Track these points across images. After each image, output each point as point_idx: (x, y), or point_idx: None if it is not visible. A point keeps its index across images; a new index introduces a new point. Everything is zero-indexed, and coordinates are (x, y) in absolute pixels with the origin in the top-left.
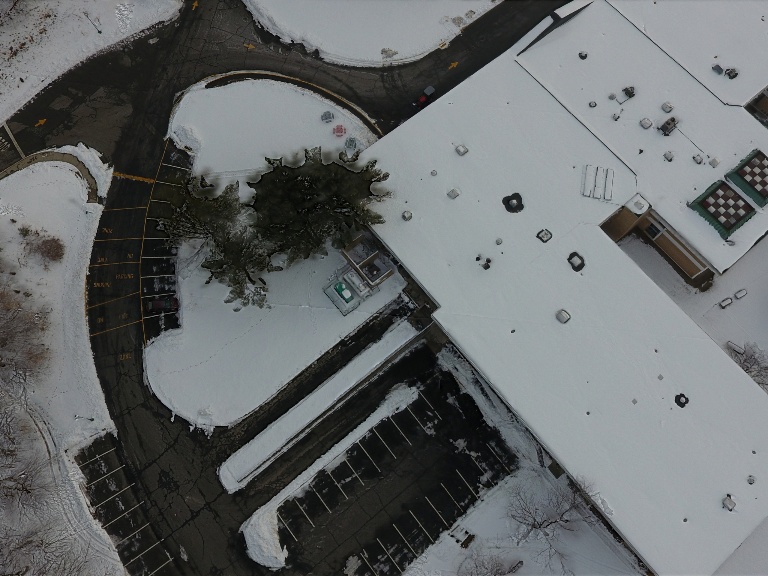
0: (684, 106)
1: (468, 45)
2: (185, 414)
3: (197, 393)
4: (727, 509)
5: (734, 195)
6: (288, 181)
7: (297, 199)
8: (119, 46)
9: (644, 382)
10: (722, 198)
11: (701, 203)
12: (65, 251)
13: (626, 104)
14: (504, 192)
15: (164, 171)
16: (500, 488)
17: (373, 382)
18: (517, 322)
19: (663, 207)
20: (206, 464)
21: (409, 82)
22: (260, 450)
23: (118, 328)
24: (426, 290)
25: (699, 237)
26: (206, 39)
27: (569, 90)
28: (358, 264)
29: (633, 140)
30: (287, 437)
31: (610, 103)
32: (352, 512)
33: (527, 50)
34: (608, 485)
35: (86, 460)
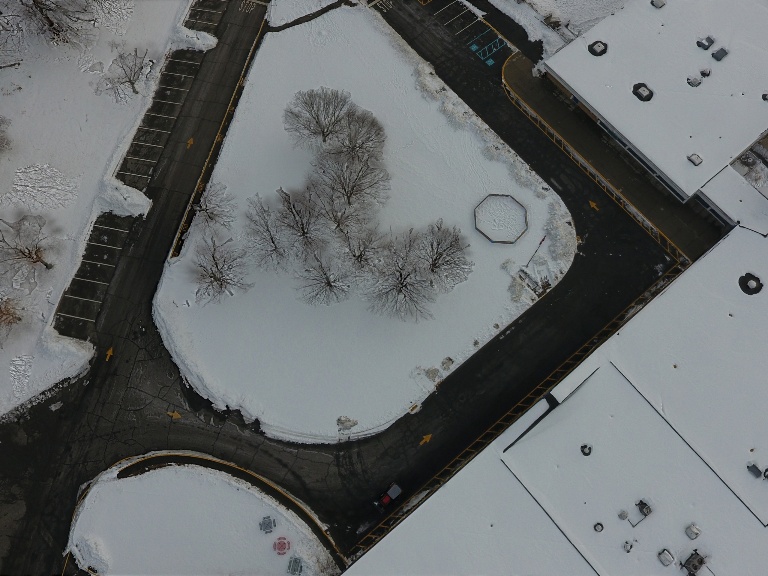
0: (713, 529)
1: (444, 408)
2: None
3: None
4: None
5: None
6: None
7: None
8: (13, 416)
9: None
10: None
11: None
12: None
13: (640, 526)
14: None
15: None
16: None
17: None
18: None
19: None
20: None
21: (370, 466)
22: None
23: None
24: None
25: None
26: (121, 404)
27: (569, 505)
28: None
29: None
30: None
31: (620, 525)
32: None
33: (516, 443)
34: None
35: None
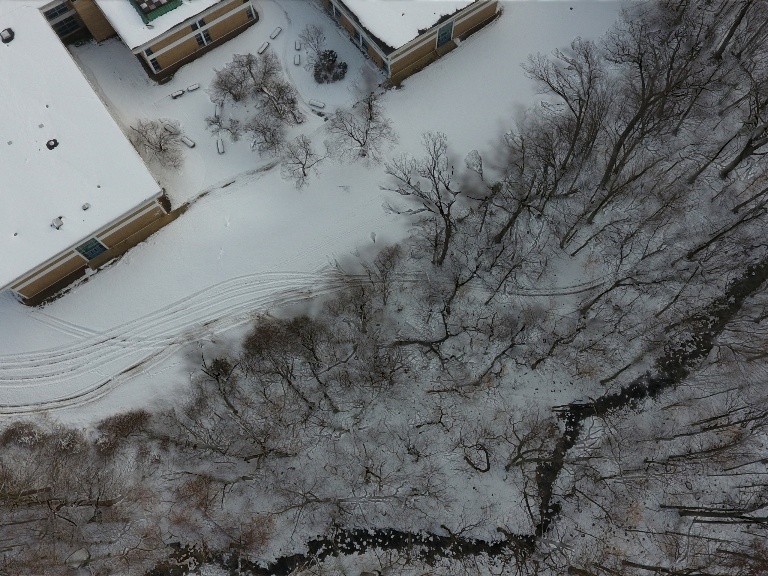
0: None
1: None
2: None
3: None
4: (55, 227)
5: None
6: None
7: None
8: None
9: (25, 129)
10: None
11: None
12: None
13: None
14: None
15: None
16: None
17: None
18: None
19: None
20: None
21: None
22: None
23: None
24: None
25: (123, 21)
26: None
27: None
28: None
29: None
30: None
31: None
32: None
33: None
34: None
35: None
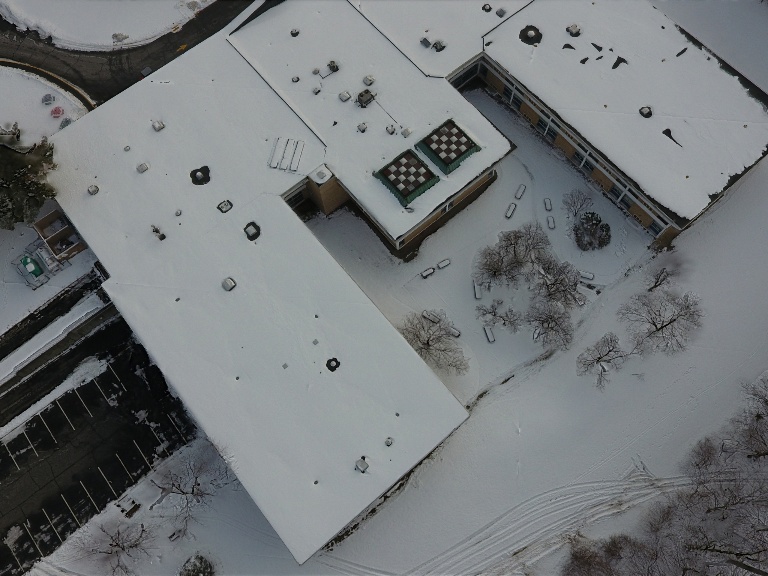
0: (386, 79)
1: (200, 28)
2: None
3: None
4: (360, 471)
5: (417, 163)
6: None
7: None
8: None
9: (298, 347)
10: (404, 166)
11: (382, 171)
12: None
13: (329, 78)
14: (193, 165)
15: None
16: (173, 458)
17: (64, 355)
18: (183, 290)
19: (347, 176)
20: None
21: (136, 65)
22: None
23: None
24: (99, 261)
25: (378, 205)
26: None
27: (275, 66)
28: (45, 238)
29: (329, 113)
30: None
31: (313, 78)
32: (22, 483)
33: (240, 29)
34: (244, 448)
35: None
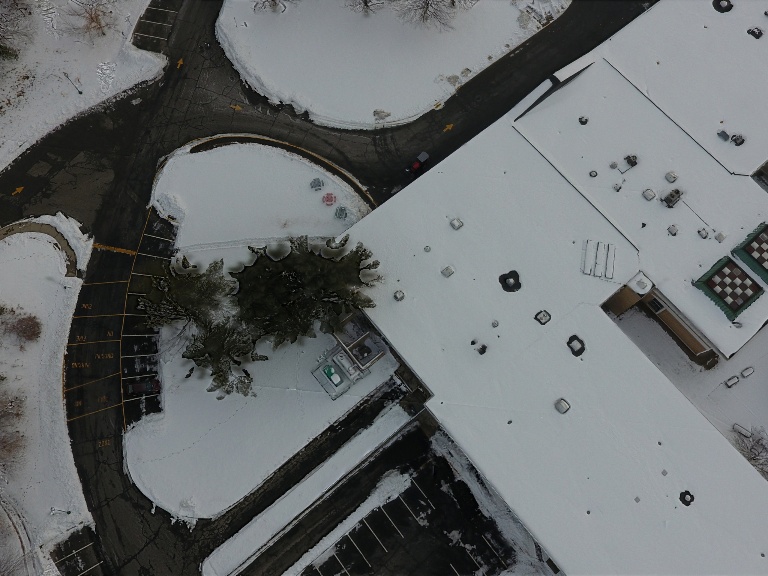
0: (689, 176)
1: (464, 106)
2: (166, 506)
3: (179, 483)
4: None
5: (741, 273)
6: (272, 277)
7: (281, 294)
8: (100, 107)
9: (647, 478)
10: (729, 277)
11: (707, 282)
12: (42, 329)
13: (628, 173)
14: (501, 270)
15: (146, 242)
16: None
17: (364, 469)
18: (514, 412)
19: (667, 286)
20: (188, 560)
21: (402, 146)
22: (245, 545)
23: (97, 412)
24: (419, 377)
25: (704, 319)
26: (191, 100)
27: (569, 158)
28: (348, 346)
29: (635, 213)
30: (273, 532)
31: (611, 172)
32: None
33: (525, 115)
34: None
35: (62, 556)
